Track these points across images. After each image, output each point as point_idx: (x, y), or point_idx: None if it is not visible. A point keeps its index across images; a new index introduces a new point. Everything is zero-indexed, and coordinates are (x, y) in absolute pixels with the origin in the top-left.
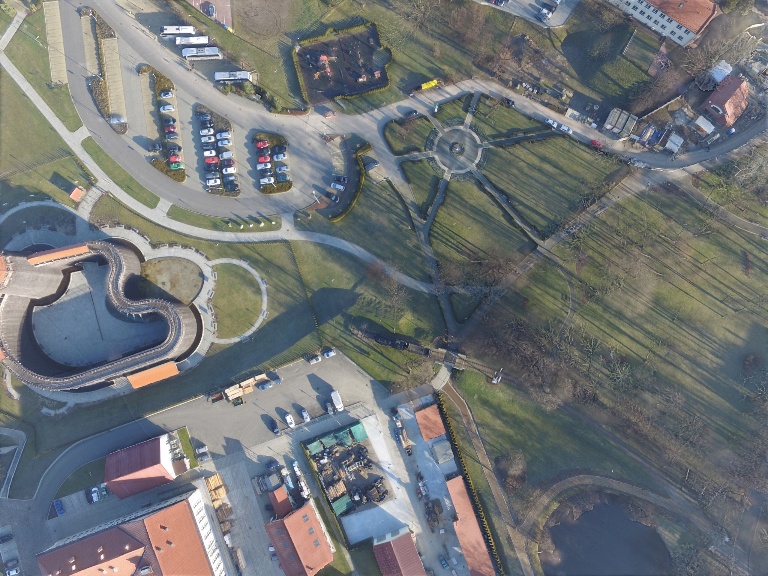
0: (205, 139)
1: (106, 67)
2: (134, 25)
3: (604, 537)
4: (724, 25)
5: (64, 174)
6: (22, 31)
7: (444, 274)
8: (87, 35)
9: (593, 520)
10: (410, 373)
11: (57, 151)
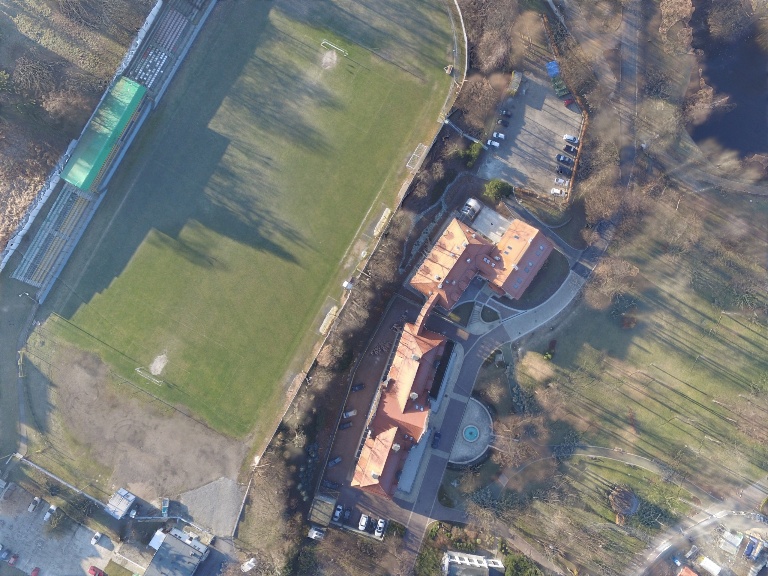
0: None
1: None
2: None
3: (748, 137)
4: None
5: None
6: None
7: None
8: None
9: (761, 153)
10: None
11: None
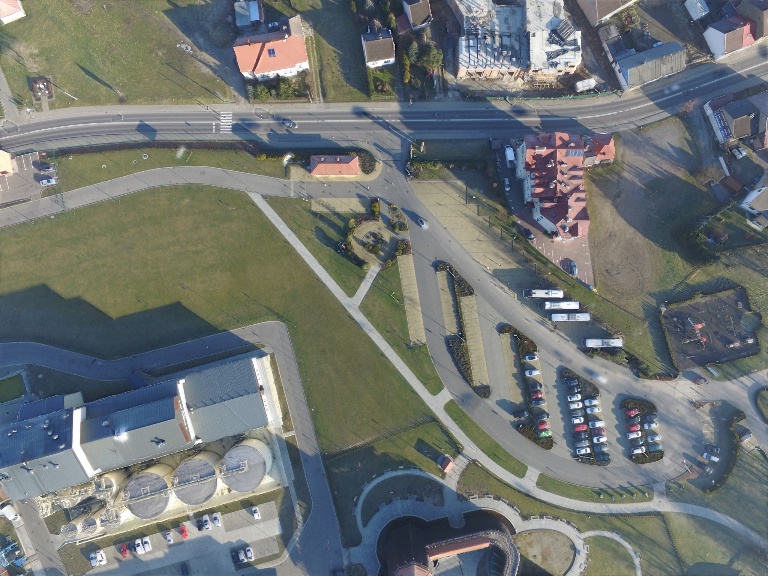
0: (574, 406)
1: (465, 326)
2: (492, 282)
3: None
4: None
5: (429, 441)
6: (377, 286)
7: None
8: (444, 291)
9: None
10: None
11: (420, 416)
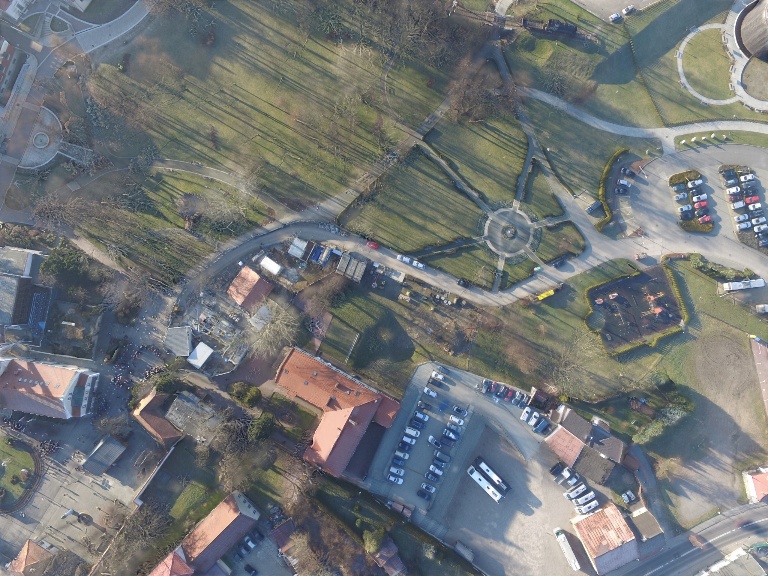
0: (762, 220)
1: None
2: None
3: None
4: (256, 374)
5: None
6: None
7: (510, 106)
8: None
9: None
10: (536, 5)
11: None
